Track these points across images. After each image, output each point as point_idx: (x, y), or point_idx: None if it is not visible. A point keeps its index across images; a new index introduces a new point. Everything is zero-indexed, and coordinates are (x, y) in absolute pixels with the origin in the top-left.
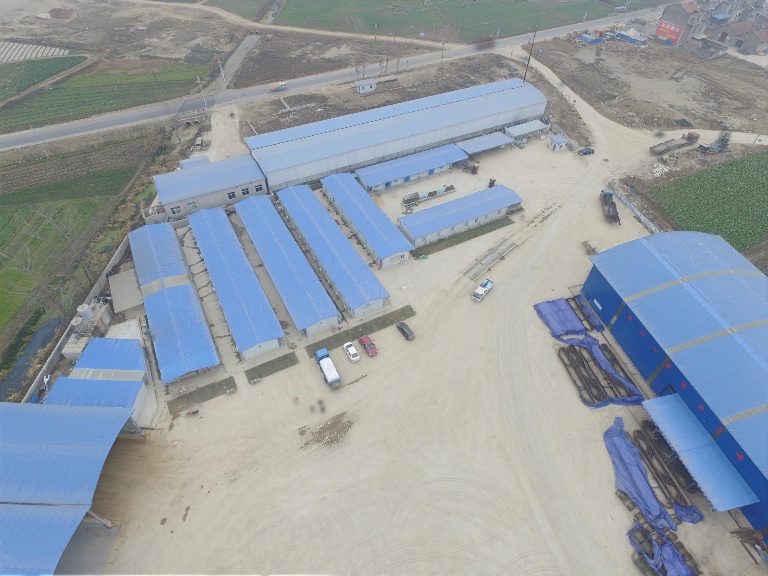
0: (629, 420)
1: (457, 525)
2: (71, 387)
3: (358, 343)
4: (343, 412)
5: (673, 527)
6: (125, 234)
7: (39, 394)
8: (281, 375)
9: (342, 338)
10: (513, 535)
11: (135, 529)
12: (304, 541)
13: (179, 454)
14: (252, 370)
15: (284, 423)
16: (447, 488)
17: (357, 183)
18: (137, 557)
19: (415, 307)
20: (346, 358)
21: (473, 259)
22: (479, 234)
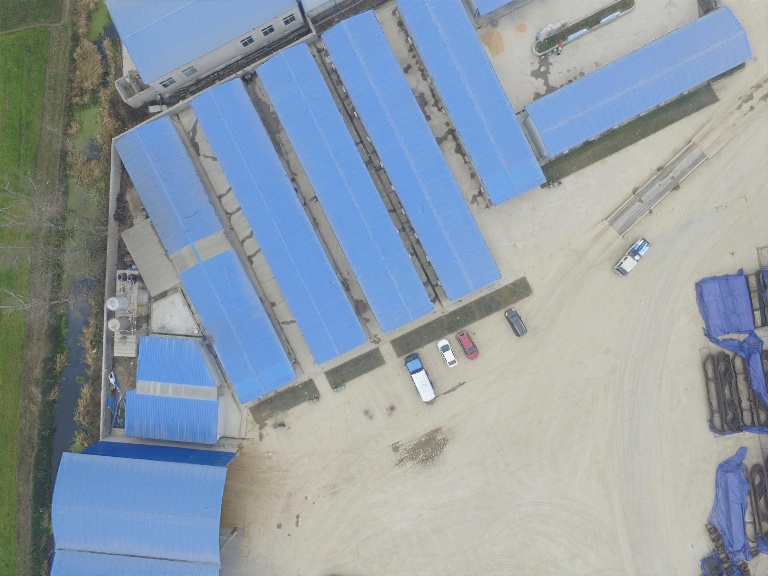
0: (754, 451)
1: (544, 544)
2: (145, 405)
3: (455, 338)
4: (438, 428)
5: (748, 560)
6: (109, 136)
7: (112, 394)
8: (366, 380)
9: (435, 329)
10: (594, 555)
11: (257, 531)
12: (405, 549)
13: (277, 466)
14: (333, 372)
15: (376, 438)
16: (539, 512)
17: (460, 5)
18: (266, 553)
19: (532, 281)
20: (440, 359)
21: (630, 188)
22: (651, 130)
